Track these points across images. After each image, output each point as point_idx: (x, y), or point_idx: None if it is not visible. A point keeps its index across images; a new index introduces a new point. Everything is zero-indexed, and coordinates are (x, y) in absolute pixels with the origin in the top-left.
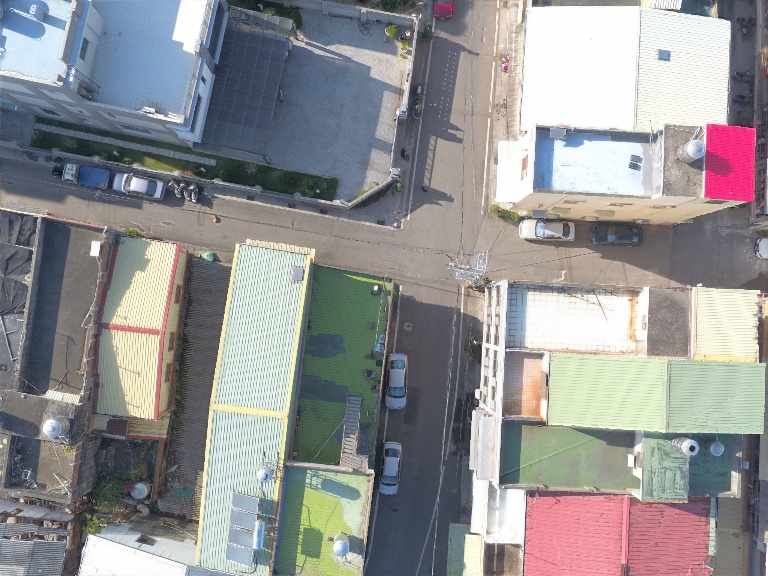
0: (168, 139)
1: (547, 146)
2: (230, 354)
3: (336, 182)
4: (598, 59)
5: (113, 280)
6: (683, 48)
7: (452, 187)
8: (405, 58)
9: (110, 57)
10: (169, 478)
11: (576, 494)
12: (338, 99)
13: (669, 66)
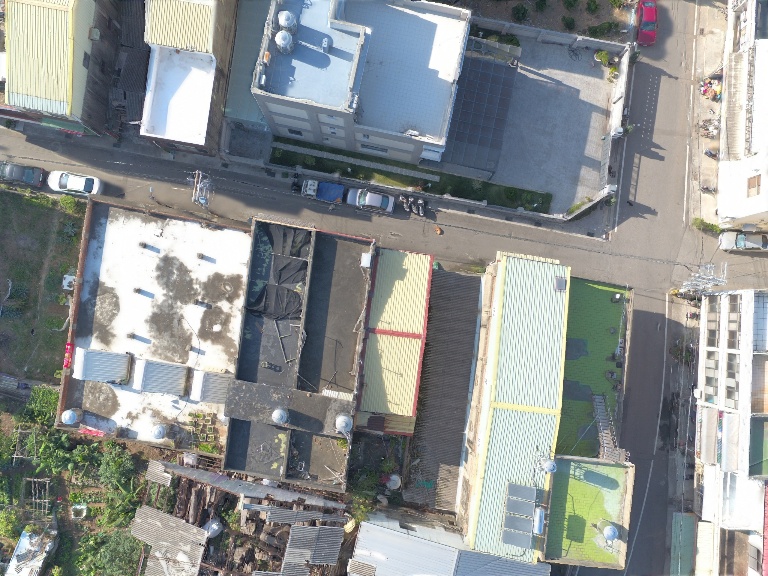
0: (398, 157)
1: None
2: (505, 357)
3: (551, 197)
4: None
5: (376, 288)
6: None
7: (656, 201)
8: (611, 82)
9: (372, 84)
10: (412, 470)
11: None
12: (550, 120)
13: None
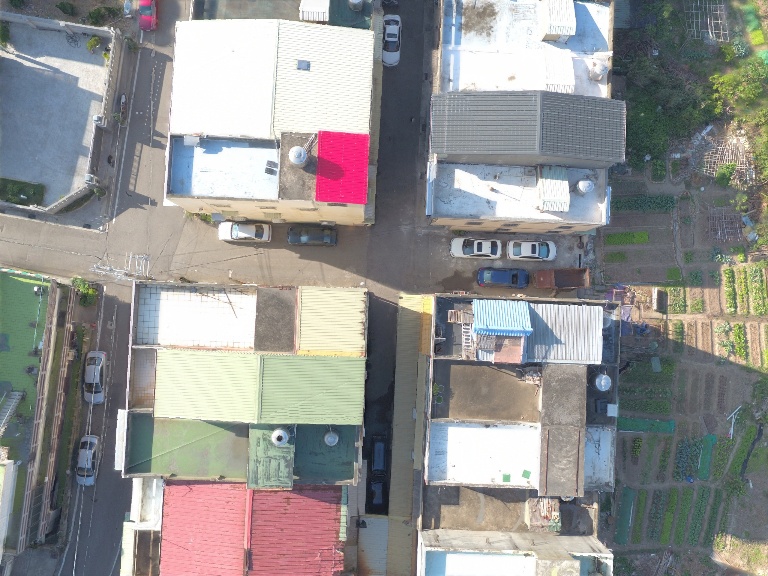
0: None
1: (187, 153)
2: None
3: (41, 188)
4: (239, 70)
5: None
6: (322, 58)
7: (156, 192)
8: None
9: None
10: None
11: (206, 483)
12: (46, 109)
13: (307, 75)
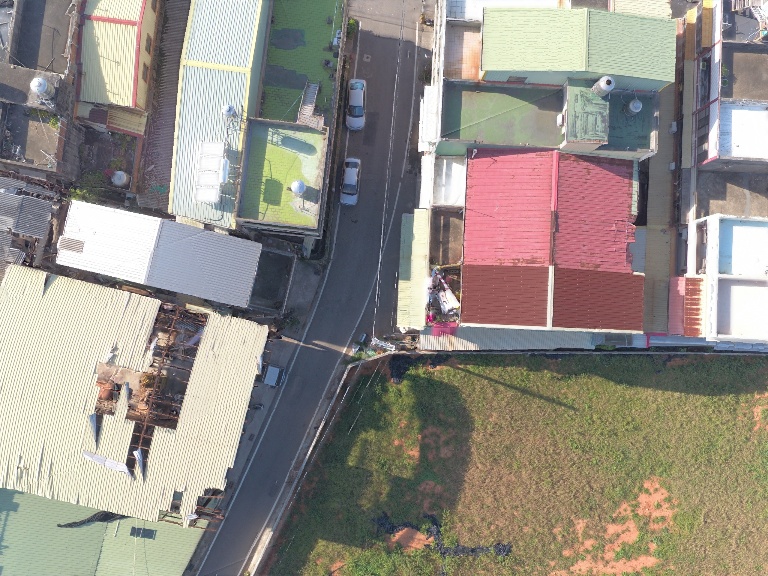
0: None
1: None
2: (199, 19)
3: None
4: None
5: None
6: None
7: None
8: None
9: None
10: (147, 176)
11: (511, 153)
12: None
13: None
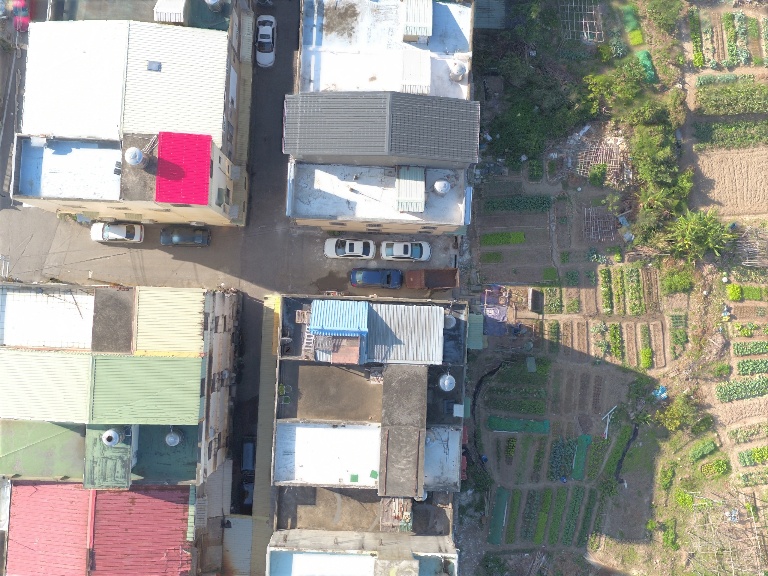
0: None
1: (36, 154)
2: None
3: None
4: (89, 71)
5: None
6: (173, 59)
7: None
8: None
9: None
10: None
11: (51, 483)
12: None
13: (158, 76)
